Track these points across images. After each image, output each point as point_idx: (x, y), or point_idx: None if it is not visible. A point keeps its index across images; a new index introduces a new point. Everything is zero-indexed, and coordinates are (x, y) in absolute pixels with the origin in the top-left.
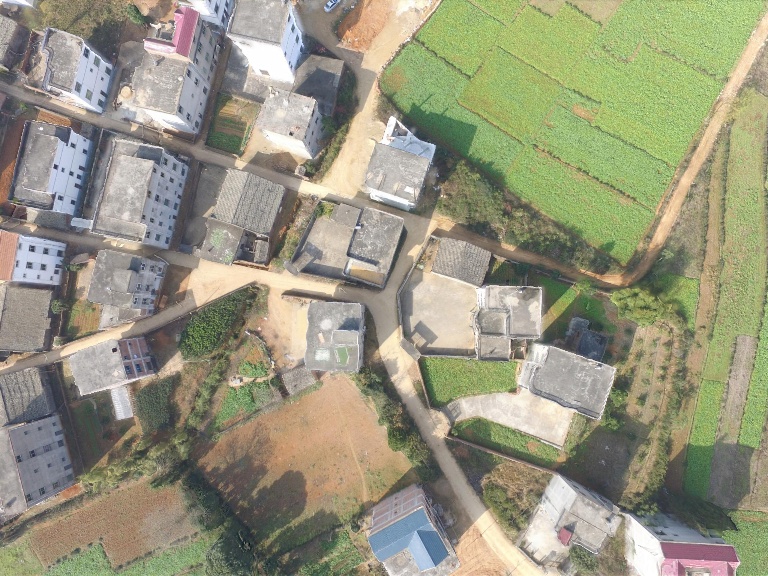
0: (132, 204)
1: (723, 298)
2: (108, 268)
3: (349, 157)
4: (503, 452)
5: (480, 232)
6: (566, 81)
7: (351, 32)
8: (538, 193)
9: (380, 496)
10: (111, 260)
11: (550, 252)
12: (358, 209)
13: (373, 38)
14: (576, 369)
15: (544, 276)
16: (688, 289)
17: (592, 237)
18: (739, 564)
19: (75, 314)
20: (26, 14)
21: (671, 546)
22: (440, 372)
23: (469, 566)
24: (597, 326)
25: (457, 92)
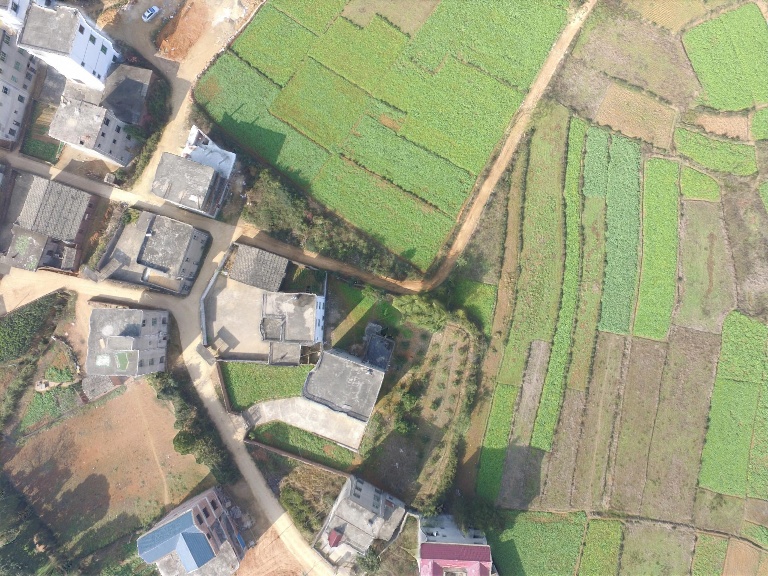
0: None
1: (520, 304)
2: None
3: None
4: (300, 455)
5: (283, 239)
6: (374, 91)
7: (167, 42)
8: (342, 201)
9: (181, 499)
10: None
11: (351, 259)
12: None
13: (189, 48)
14: (348, 374)
15: (344, 282)
16: (485, 295)
17: (394, 244)
18: (491, 564)
19: None
20: None
21: (430, 547)
22: (241, 377)
23: (266, 567)
24: (393, 331)
25: (268, 101)
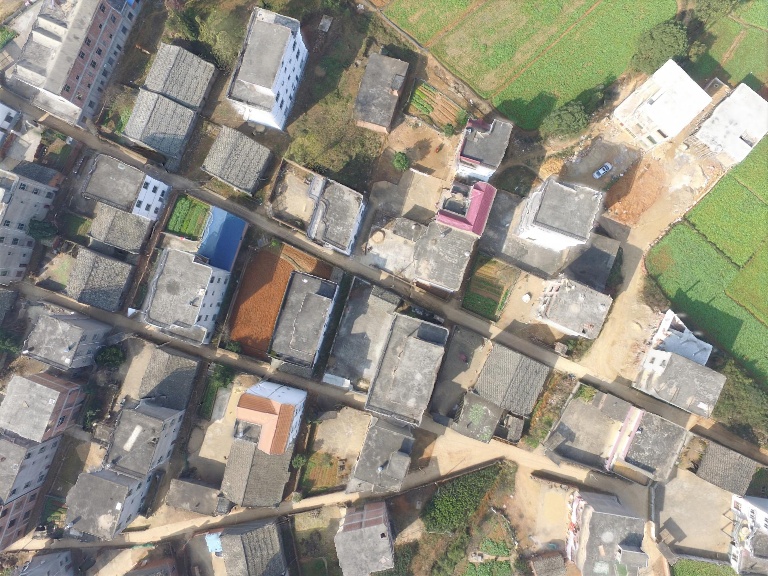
0: (419, 391)
1: None
2: (378, 446)
3: (610, 338)
4: None
5: (741, 434)
6: None
7: (620, 204)
8: None
9: None
10: (382, 438)
11: None
12: (626, 402)
13: (642, 212)
14: None
15: None
16: None
17: None
18: None
19: (311, 467)
20: (271, 135)
21: None
22: (686, 572)
23: None
24: None
25: (725, 282)
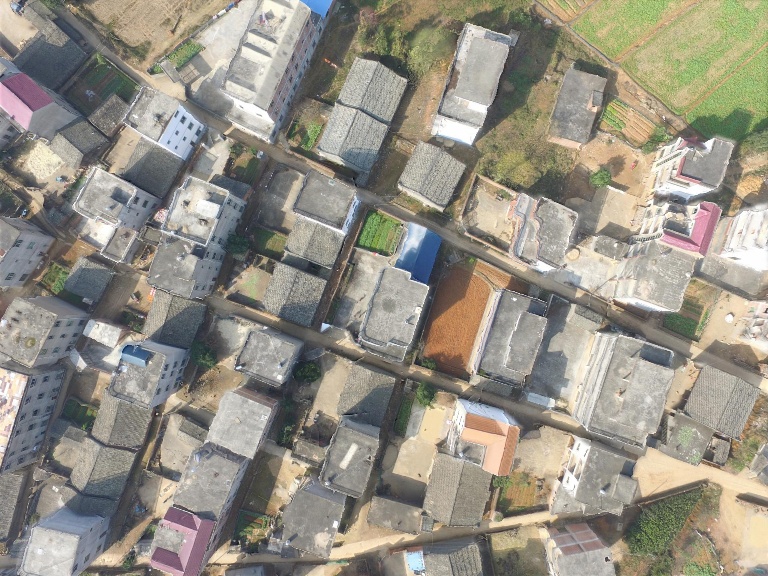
0: (648, 414)
1: None
2: (599, 468)
3: None
4: None
5: None
6: None
7: None
8: None
9: None
10: (602, 460)
11: None
12: None
13: None
14: None
15: None
16: None
17: None
18: None
19: (508, 486)
20: (460, 150)
21: None
22: None
23: None
24: None
25: None
